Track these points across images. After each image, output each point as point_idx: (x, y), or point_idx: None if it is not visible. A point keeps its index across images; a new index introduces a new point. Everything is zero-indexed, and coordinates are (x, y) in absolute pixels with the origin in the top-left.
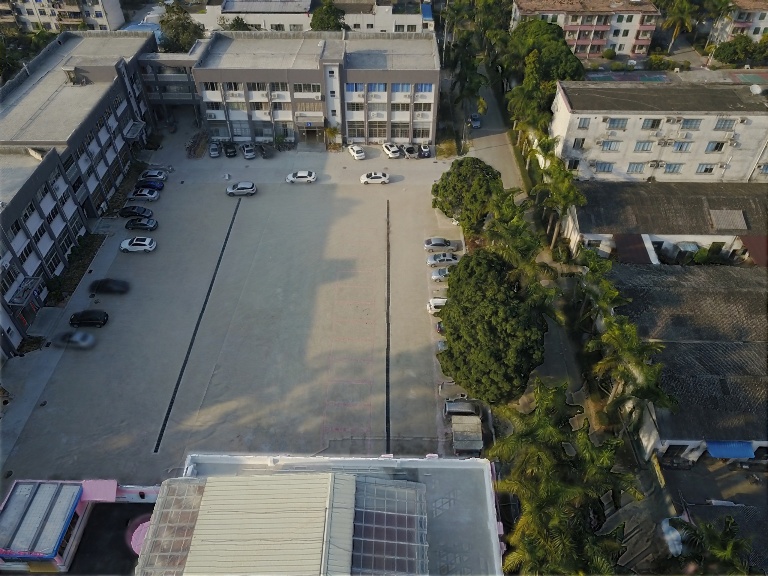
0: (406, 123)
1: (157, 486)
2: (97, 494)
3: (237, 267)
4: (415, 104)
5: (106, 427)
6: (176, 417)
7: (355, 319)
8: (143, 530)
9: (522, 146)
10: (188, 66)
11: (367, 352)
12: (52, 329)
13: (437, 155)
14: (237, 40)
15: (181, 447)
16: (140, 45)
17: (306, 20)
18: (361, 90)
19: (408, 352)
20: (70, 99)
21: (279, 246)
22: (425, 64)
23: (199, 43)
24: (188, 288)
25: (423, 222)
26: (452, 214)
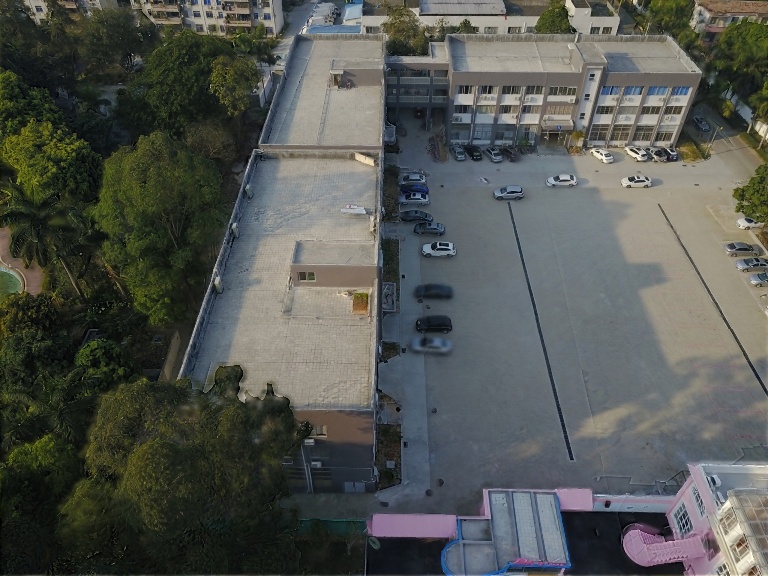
0: (651, 126)
1: (629, 495)
2: (574, 503)
3: (546, 272)
4: (667, 107)
5: (509, 434)
6: (572, 424)
7: (696, 325)
8: (633, 540)
9: (764, 149)
10: (433, 69)
11: (727, 358)
12: (400, 335)
13: (684, 158)
14: (469, 43)
15: (596, 455)
16: (375, 48)
17: (502, 22)
18: (616, 93)
19: (767, 358)
20: (345, 103)
21: (577, 251)
22: (676, 67)
23: (433, 46)
24: (509, 293)
25: (707, 226)
26: (766, 219)
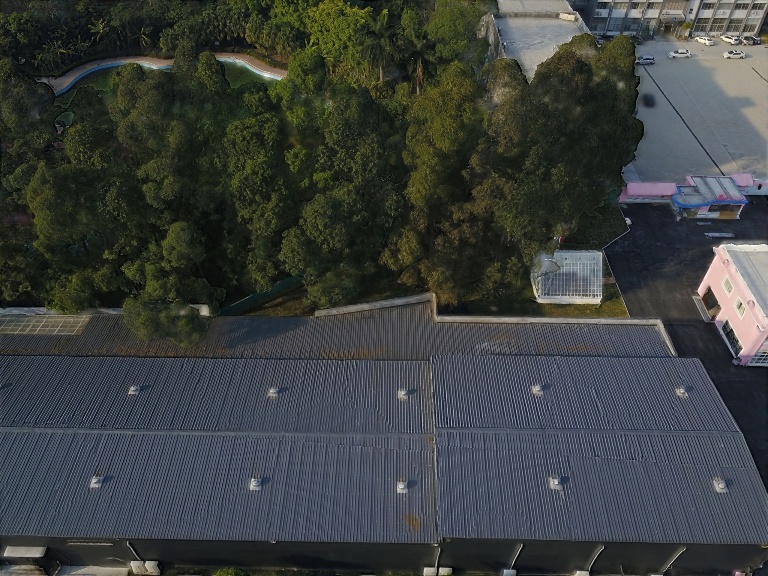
0: (741, 20)
1: None
2: (742, 182)
3: (683, 101)
4: (754, 4)
5: (685, 170)
6: (723, 166)
7: None
8: None
9: None
10: None
11: None
12: None
13: (765, 43)
14: None
15: None
16: None
17: None
18: None
19: None
20: None
21: (701, 90)
22: None
23: None
24: (661, 111)
25: None
26: None
